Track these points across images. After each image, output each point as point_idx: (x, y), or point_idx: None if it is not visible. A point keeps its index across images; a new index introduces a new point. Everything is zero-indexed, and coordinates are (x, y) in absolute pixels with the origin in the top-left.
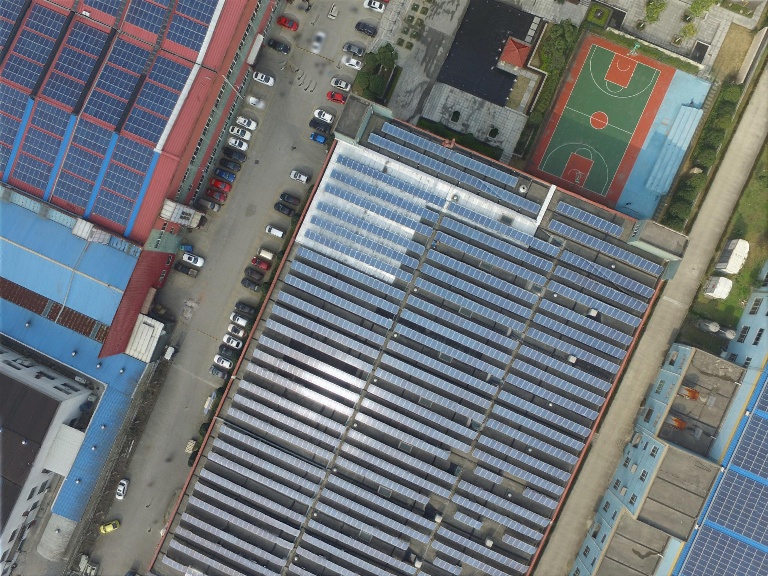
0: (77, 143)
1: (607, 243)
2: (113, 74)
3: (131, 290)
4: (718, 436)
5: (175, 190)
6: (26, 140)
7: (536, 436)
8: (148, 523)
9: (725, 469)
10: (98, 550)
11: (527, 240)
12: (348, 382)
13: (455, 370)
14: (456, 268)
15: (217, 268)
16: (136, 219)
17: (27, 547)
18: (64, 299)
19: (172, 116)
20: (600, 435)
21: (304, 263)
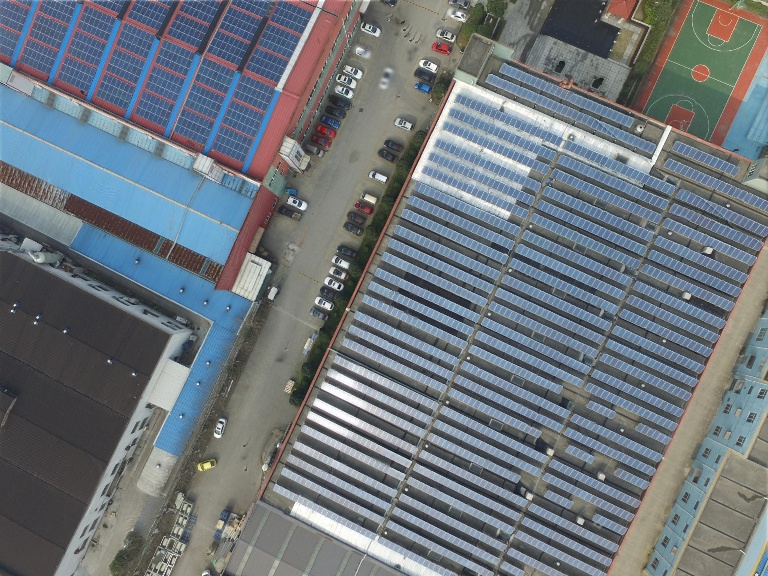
0: (200, 82)
1: (723, 182)
2: (236, 16)
3: (247, 225)
4: None
5: (292, 129)
6: (150, 79)
7: (649, 372)
8: (244, 462)
9: None
10: (194, 488)
11: (643, 179)
12: (462, 316)
13: (569, 305)
14: (571, 205)
15: (320, 212)
16: (254, 156)
17: (123, 484)
18: (176, 236)
19: (293, 57)
20: None
21: (421, 199)
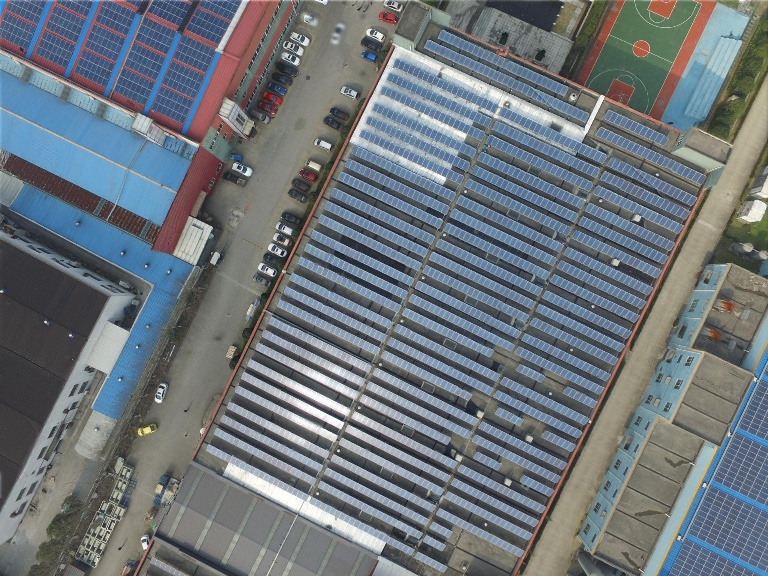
0: (140, 41)
1: (653, 151)
2: None
3: (186, 187)
4: (751, 348)
5: (233, 91)
6: (90, 37)
7: (578, 337)
8: (185, 428)
9: (758, 379)
10: (134, 453)
11: (575, 146)
12: (396, 279)
13: (501, 270)
14: (506, 172)
15: (265, 179)
16: (194, 117)
17: (63, 449)
18: (116, 198)
19: (234, 18)
20: (633, 353)
21: (358, 162)
